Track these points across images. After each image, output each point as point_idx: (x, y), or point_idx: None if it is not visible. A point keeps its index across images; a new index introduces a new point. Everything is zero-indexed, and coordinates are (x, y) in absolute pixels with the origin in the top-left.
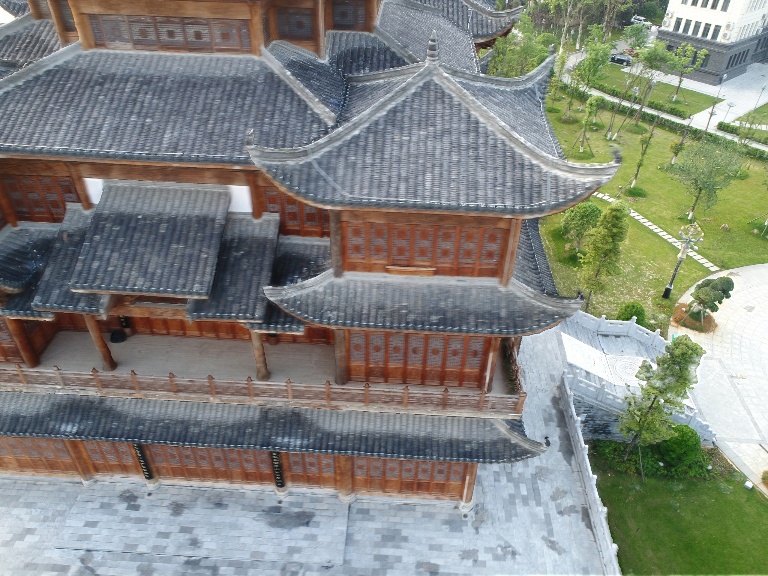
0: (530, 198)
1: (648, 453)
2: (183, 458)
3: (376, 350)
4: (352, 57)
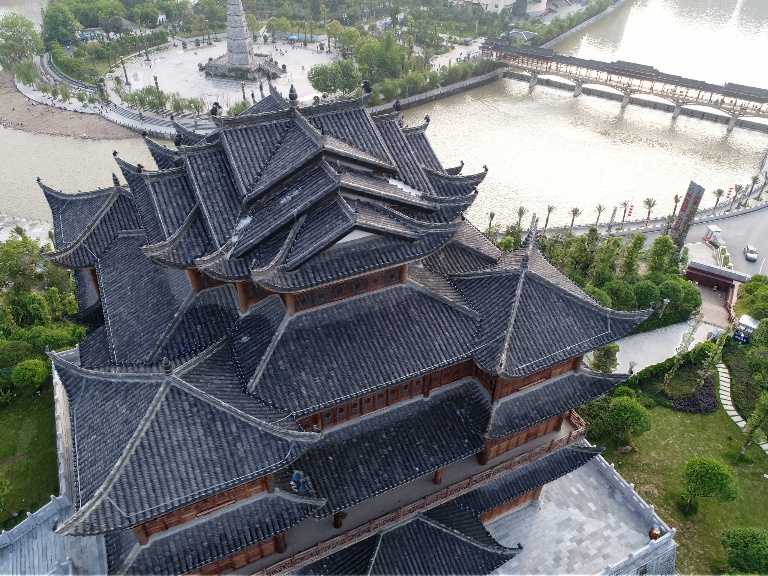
0: None
1: None
2: None
3: None
4: (256, 323)
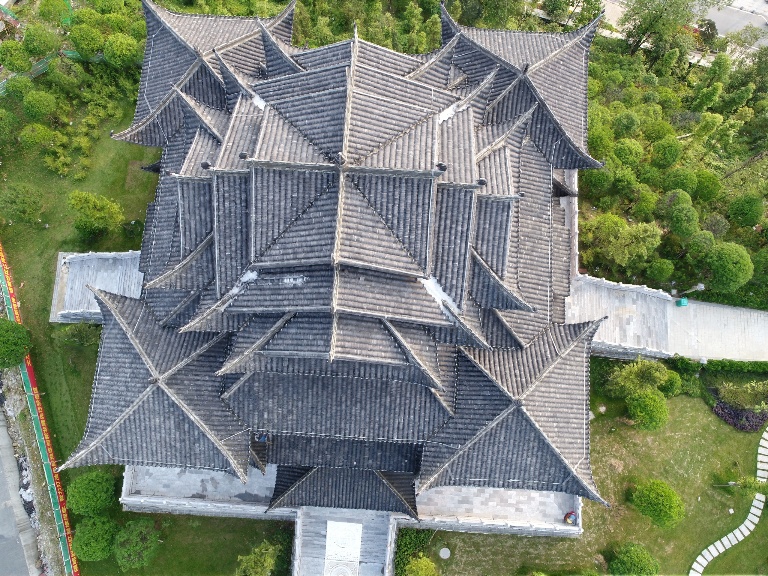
0: (91, 432)
1: (277, 567)
2: None
3: None
4: None
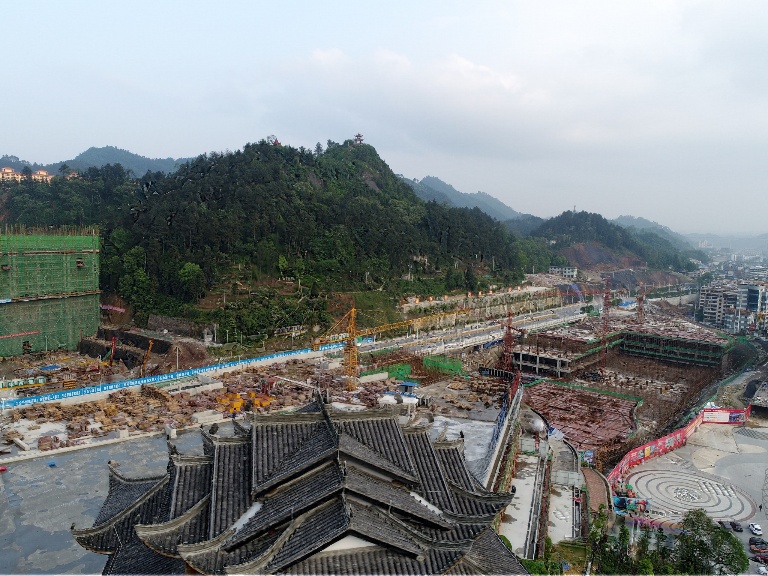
0: None
1: None
2: None
3: None
4: None
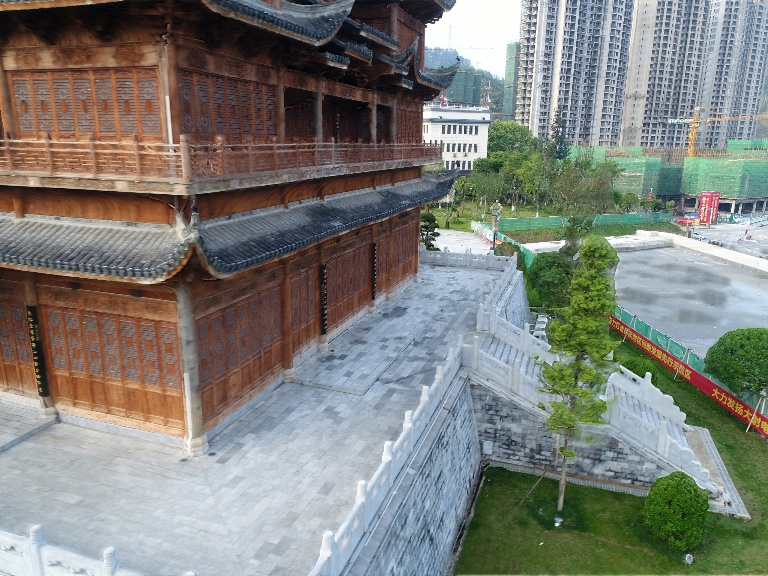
0: None
1: None
2: (337, 291)
3: (399, 128)
4: None
